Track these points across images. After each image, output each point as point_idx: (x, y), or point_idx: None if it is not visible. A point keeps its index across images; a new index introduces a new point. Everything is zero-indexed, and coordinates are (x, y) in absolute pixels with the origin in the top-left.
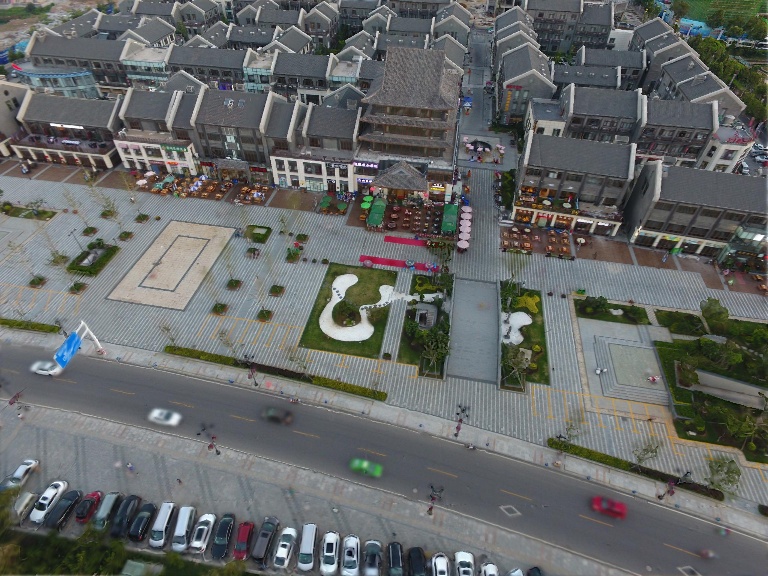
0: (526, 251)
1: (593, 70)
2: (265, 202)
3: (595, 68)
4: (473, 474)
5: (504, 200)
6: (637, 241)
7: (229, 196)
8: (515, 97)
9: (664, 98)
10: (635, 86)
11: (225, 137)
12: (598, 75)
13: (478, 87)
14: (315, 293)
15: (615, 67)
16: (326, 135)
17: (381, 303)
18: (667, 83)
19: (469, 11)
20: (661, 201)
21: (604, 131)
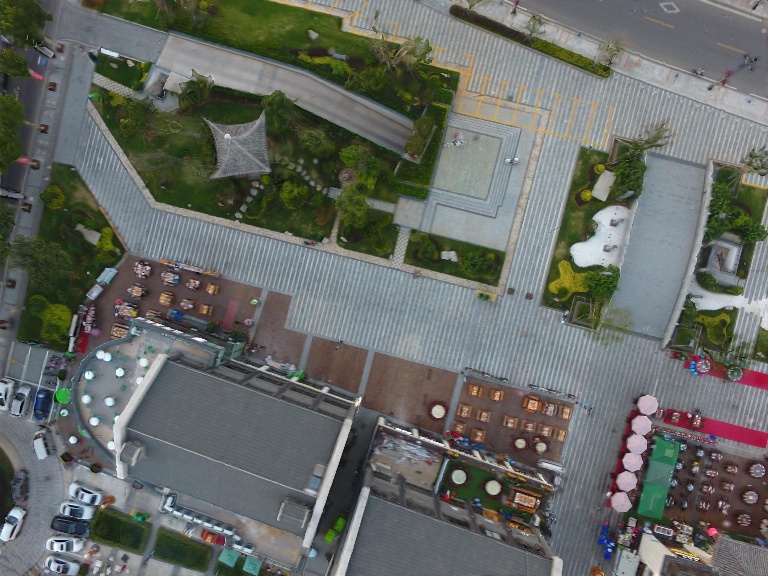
0: None
1: None
2: None
3: None
4: (699, 45)
5: None
6: None
7: None
8: None
9: None
10: None
11: None
12: None
13: None
14: None
15: None
16: None
17: None
18: None
19: None
20: None
21: None
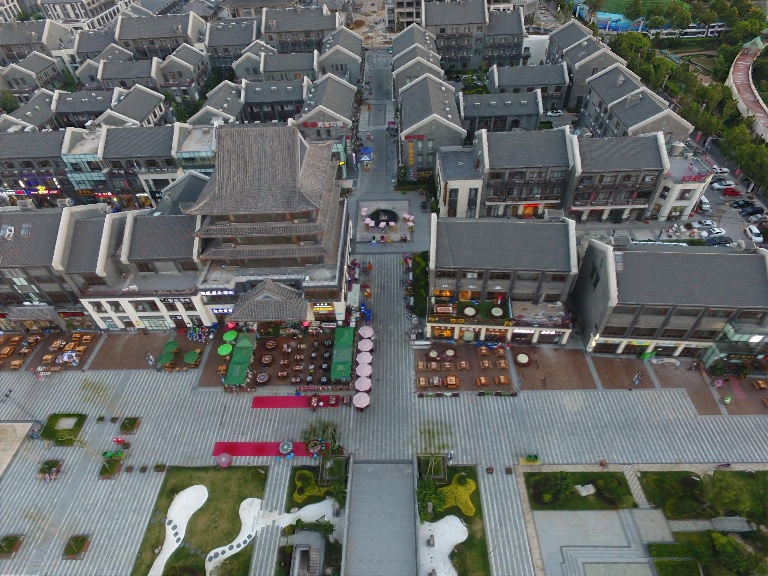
0: (450, 393)
1: (509, 97)
2: (84, 362)
3: (511, 94)
4: None
5: (417, 302)
6: (596, 348)
7: (33, 360)
8: (418, 148)
9: (595, 120)
10: (560, 104)
11: (11, 280)
12: (515, 102)
13: (380, 128)
14: (138, 539)
15: (534, 86)
16: (156, 257)
17: (240, 540)
18: (596, 103)
19: (368, 28)
20: (620, 305)
21: (531, 184)
